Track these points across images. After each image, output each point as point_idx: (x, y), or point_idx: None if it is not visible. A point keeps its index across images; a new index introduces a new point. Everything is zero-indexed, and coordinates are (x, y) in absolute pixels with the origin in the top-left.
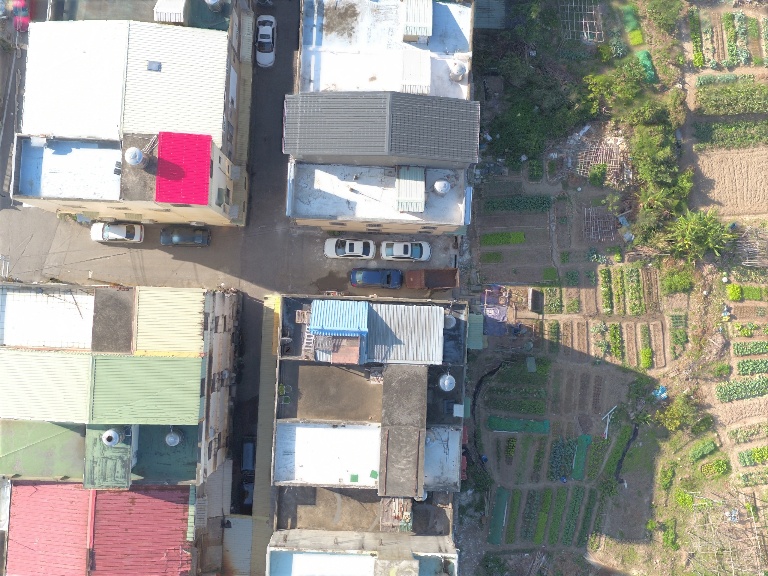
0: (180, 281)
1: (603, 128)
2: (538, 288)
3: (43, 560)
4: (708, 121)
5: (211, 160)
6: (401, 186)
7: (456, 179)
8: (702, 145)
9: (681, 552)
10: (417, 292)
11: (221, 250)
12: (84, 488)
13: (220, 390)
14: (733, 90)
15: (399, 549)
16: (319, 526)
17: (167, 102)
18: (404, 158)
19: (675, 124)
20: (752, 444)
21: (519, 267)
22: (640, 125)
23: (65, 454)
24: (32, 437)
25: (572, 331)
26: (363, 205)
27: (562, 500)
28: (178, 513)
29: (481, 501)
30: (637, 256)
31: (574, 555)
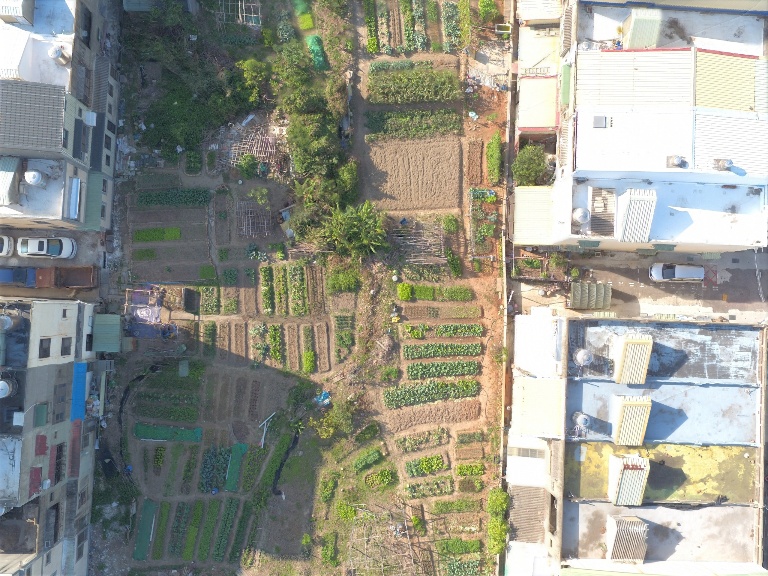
0: None
1: (268, 117)
2: (194, 287)
3: None
4: (382, 110)
5: None
6: None
7: (60, 170)
8: (373, 135)
9: (341, 568)
10: (61, 291)
11: None
12: None
13: None
14: (403, 77)
15: None
16: None
17: None
18: None
19: (335, 113)
20: (422, 453)
21: (174, 265)
22: (294, 114)
23: None
24: None
25: (230, 333)
26: None
27: (213, 513)
28: None
29: (126, 514)
30: (299, 253)
31: (225, 572)
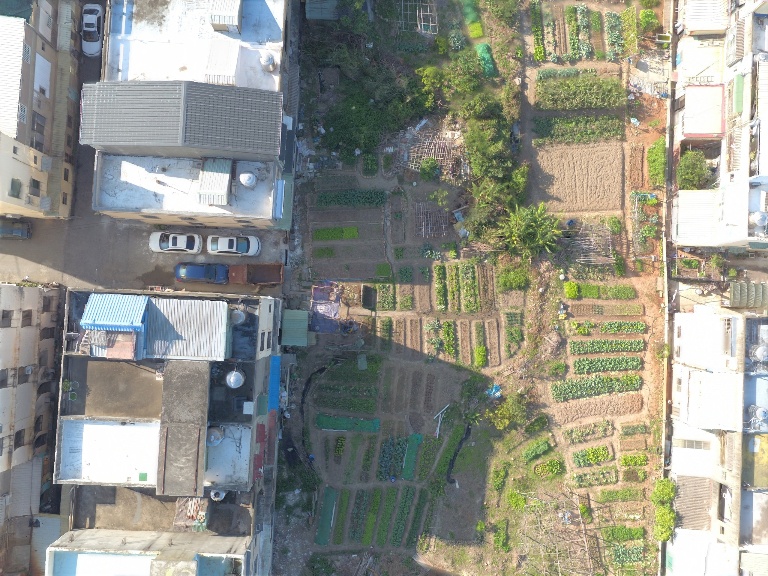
0: (1, 275)
1: (440, 122)
2: (371, 284)
3: None
4: (548, 116)
5: None
6: (204, 178)
7: (267, 172)
8: (541, 140)
9: (512, 554)
10: (245, 287)
11: (44, 243)
12: None
13: (19, 386)
14: (571, 84)
15: (185, 550)
16: (118, 526)
17: None
18: (202, 149)
19: (509, 118)
20: (587, 444)
21: (352, 263)
22: (472, 119)
23: None
24: None
25: (405, 328)
26: (171, 198)
27: (391, 500)
28: None
29: (308, 501)
30: (472, 252)
31: (403, 556)
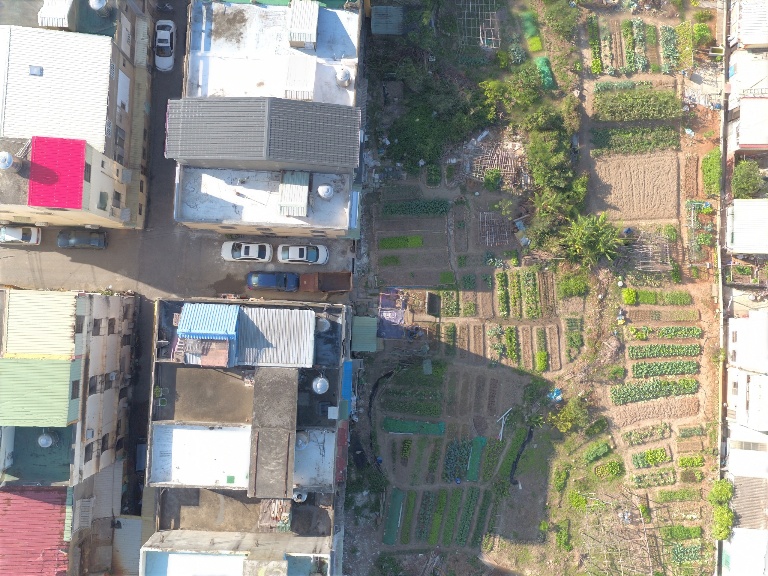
0: (78, 283)
1: (501, 133)
2: (435, 291)
3: None
4: (606, 127)
5: (88, 164)
6: (284, 191)
7: (342, 184)
8: (599, 151)
9: (574, 553)
10: (314, 295)
11: (119, 253)
12: None
13: (105, 392)
14: (629, 96)
15: (273, 550)
16: (202, 527)
17: (49, 106)
18: (284, 163)
19: (570, 130)
20: (646, 446)
21: (417, 270)
22: (534, 131)
23: None
24: None
25: (469, 334)
26: (250, 209)
27: (457, 501)
28: (55, 514)
29: (376, 502)
30: (533, 260)
31: (468, 555)
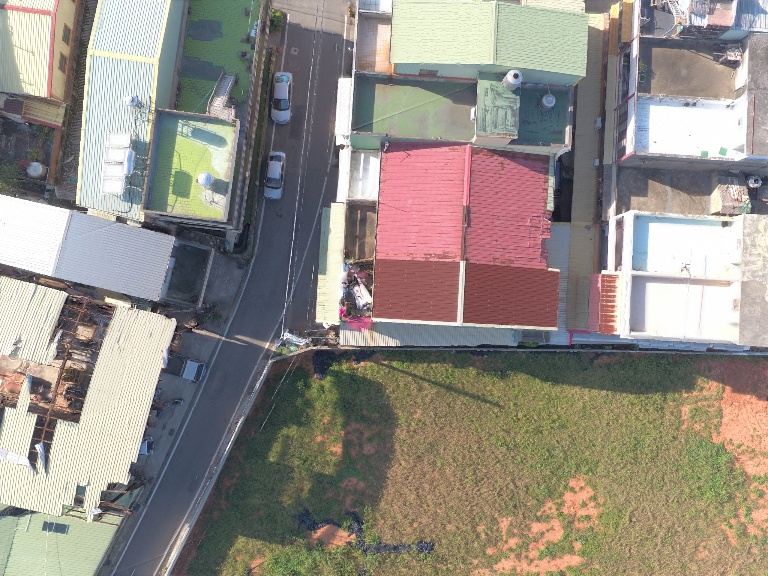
0: None
1: None
2: None
3: (416, 220)
4: None
5: None
6: None
7: None
8: None
9: None
10: None
11: None
12: (477, 134)
13: None
14: None
15: None
16: None
17: None
18: None
19: None
20: None
21: None
22: None
23: (438, 119)
24: (407, 103)
25: None
26: None
27: None
28: (540, 183)
29: None
30: None
31: None
